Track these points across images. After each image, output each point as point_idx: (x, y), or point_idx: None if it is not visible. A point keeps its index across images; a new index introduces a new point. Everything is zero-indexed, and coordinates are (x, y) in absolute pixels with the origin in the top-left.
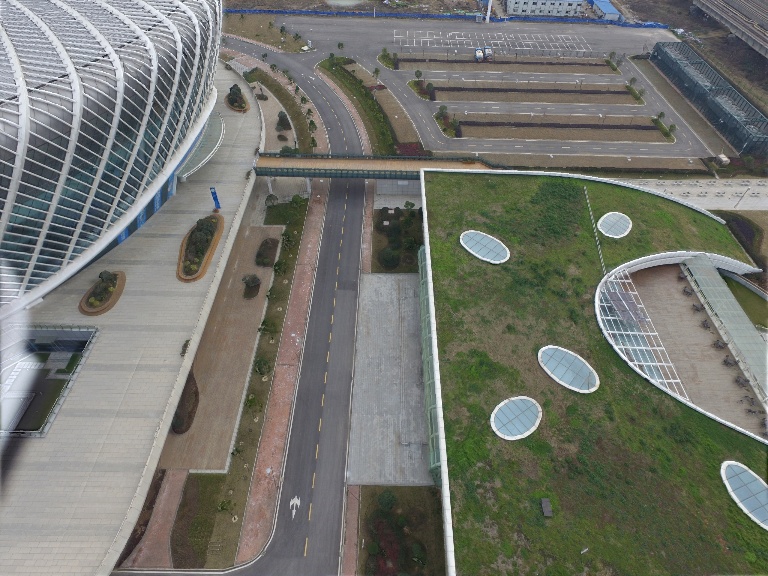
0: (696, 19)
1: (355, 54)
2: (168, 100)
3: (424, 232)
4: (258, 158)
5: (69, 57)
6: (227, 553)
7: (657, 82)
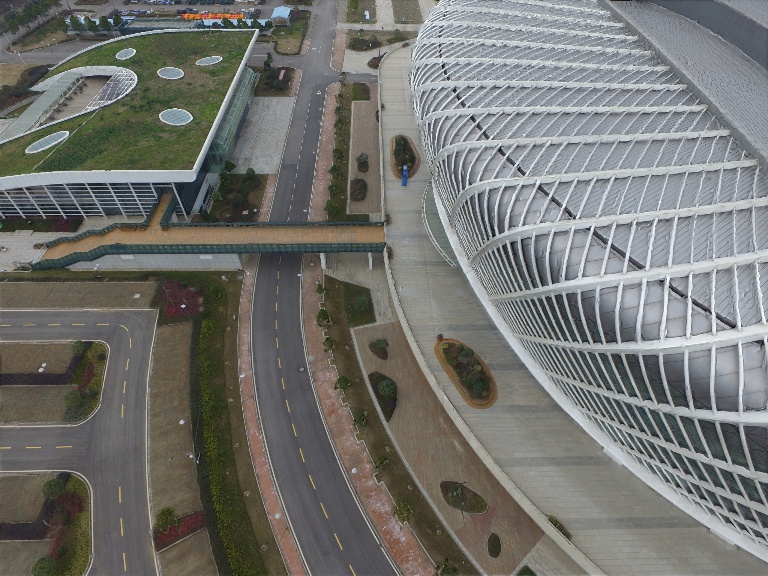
0: None
1: None
2: None
3: None
4: None
5: None
6: None
7: None
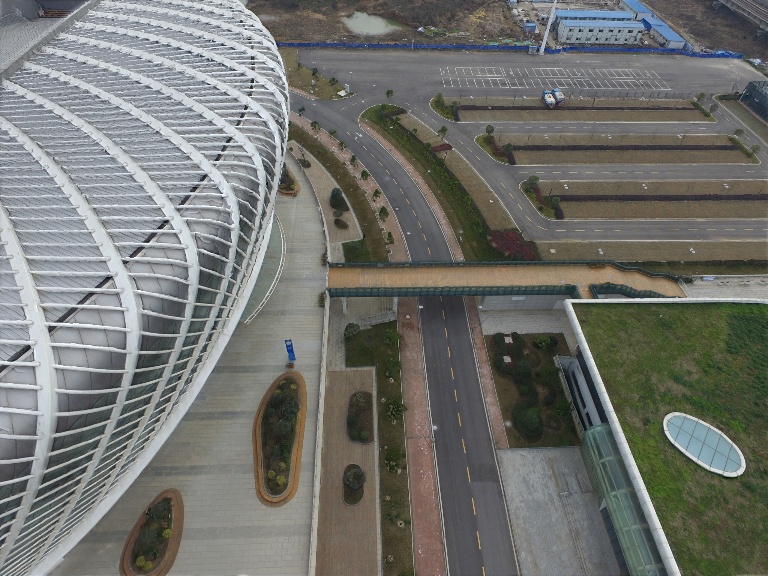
0: (765, 45)
1: (403, 100)
2: (245, 254)
3: (612, 421)
4: (328, 270)
5: (111, 241)
6: None
7: (760, 131)
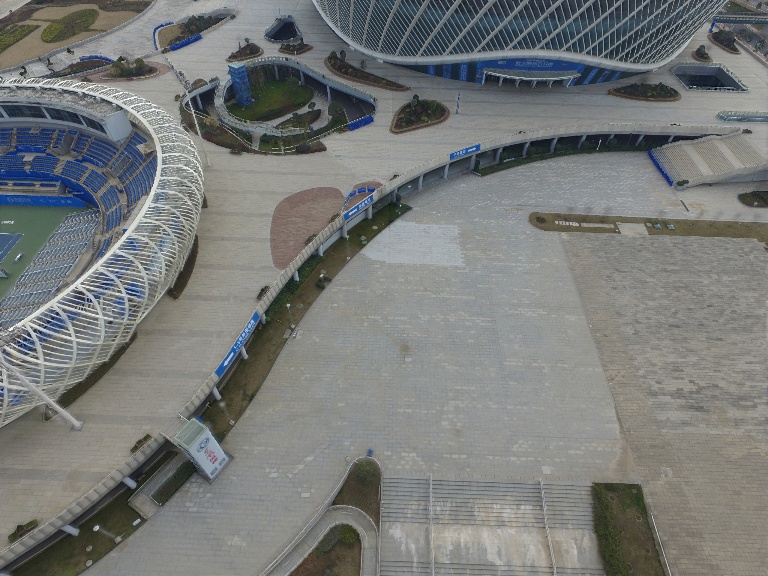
0: None
1: None
2: None
3: None
4: None
5: None
6: None
7: None
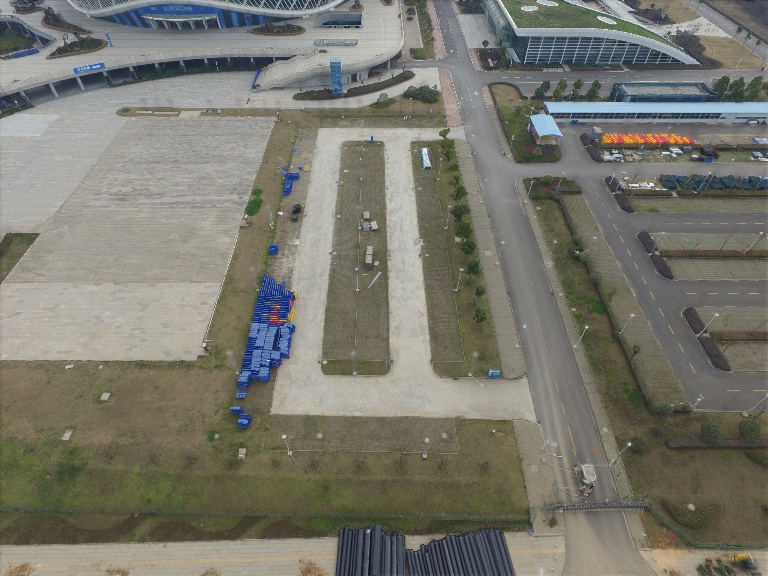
0: None
1: None
2: None
3: None
4: None
5: None
6: (432, 57)
7: None
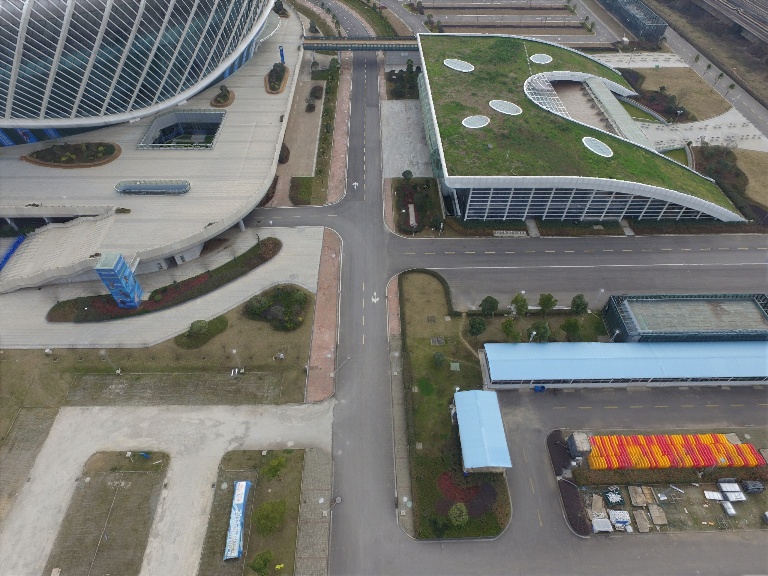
0: None
1: None
2: None
3: None
4: (303, 40)
5: None
6: (322, 200)
7: (588, 3)
